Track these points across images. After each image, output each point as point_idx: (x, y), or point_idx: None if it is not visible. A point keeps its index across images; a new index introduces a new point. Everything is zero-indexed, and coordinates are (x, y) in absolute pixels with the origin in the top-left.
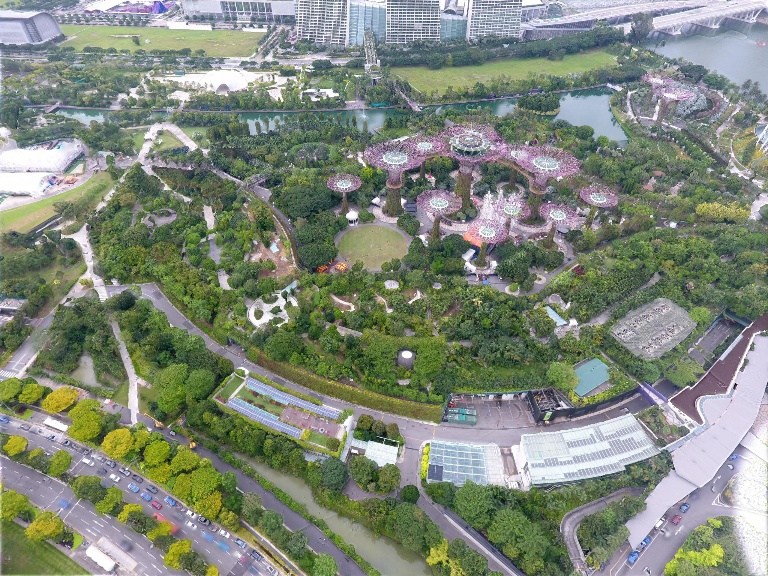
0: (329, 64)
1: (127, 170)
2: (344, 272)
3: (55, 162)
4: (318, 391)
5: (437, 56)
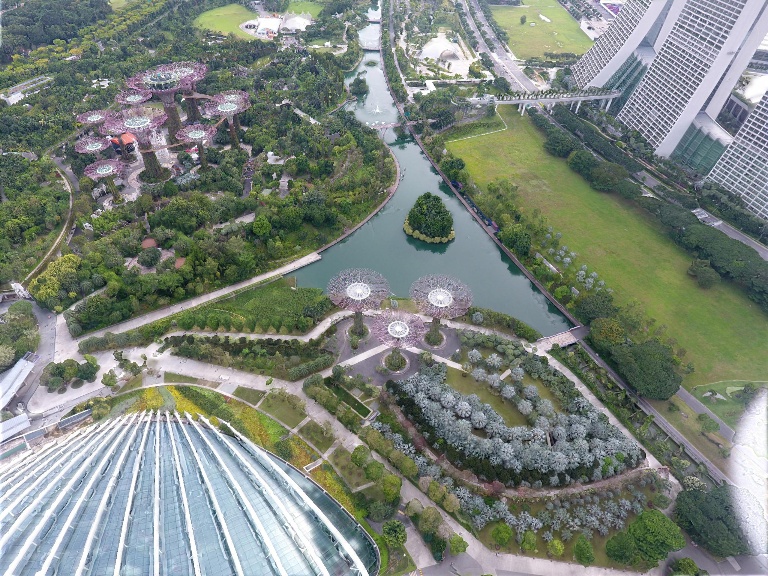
0: (503, 86)
1: None
2: None
3: (281, 26)
4: None
5: (560, 138)
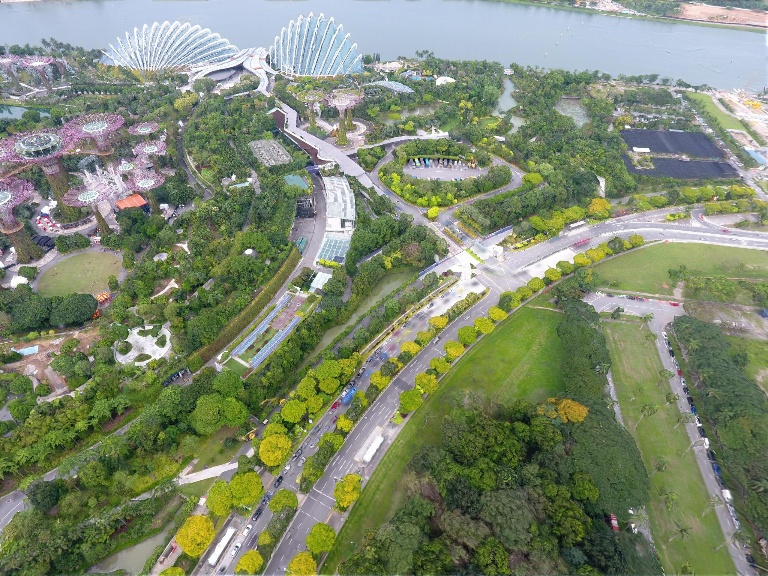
0: None
1: None
2: (110, 298)
3: None
4: (253, 319)
5: None
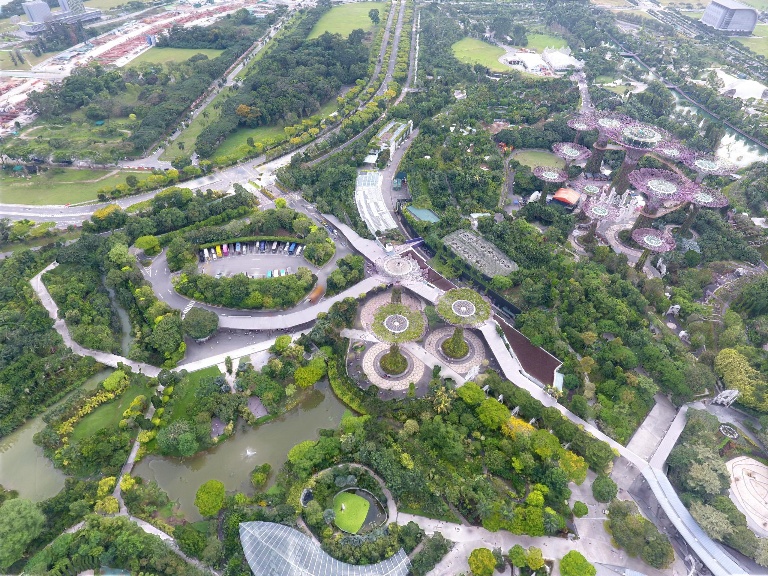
0: None
1: (564, 79)
2: None
3: (556, 62)
4: None
5: None
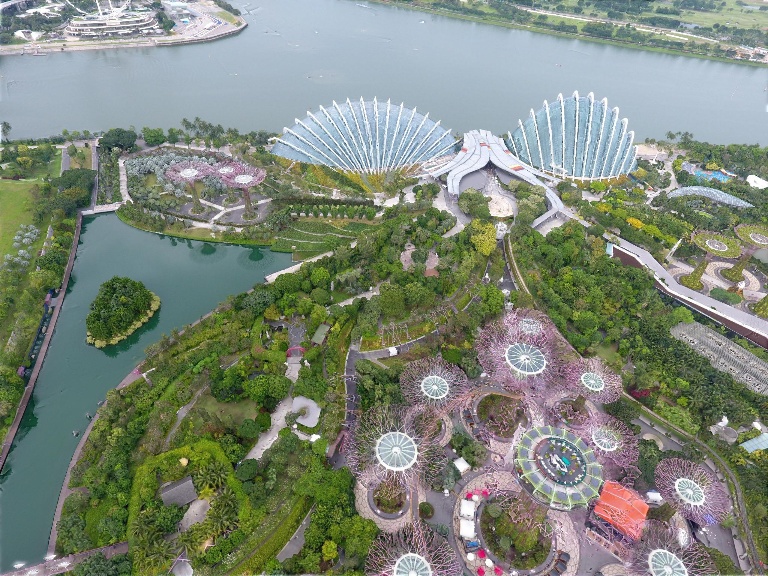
0: None
1: None
2: None
3: None
4: None
5: None
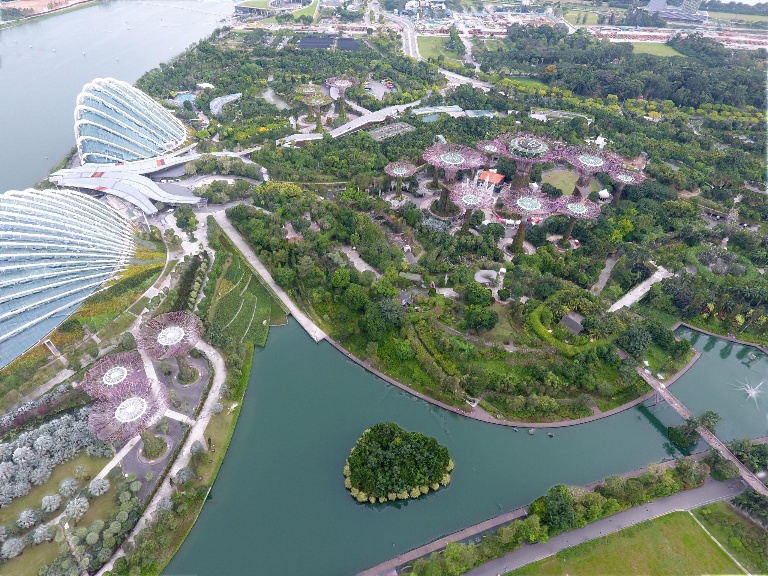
0: None
1: None
2: None
3: None
4: None
5: None
